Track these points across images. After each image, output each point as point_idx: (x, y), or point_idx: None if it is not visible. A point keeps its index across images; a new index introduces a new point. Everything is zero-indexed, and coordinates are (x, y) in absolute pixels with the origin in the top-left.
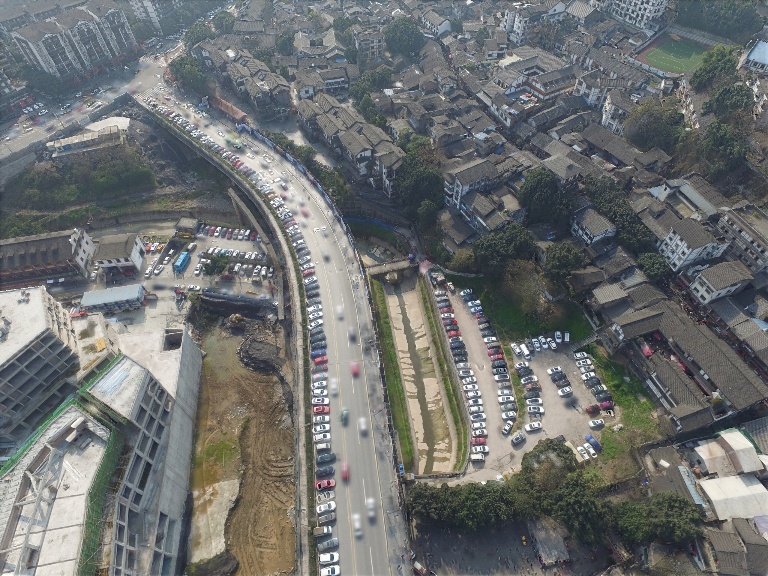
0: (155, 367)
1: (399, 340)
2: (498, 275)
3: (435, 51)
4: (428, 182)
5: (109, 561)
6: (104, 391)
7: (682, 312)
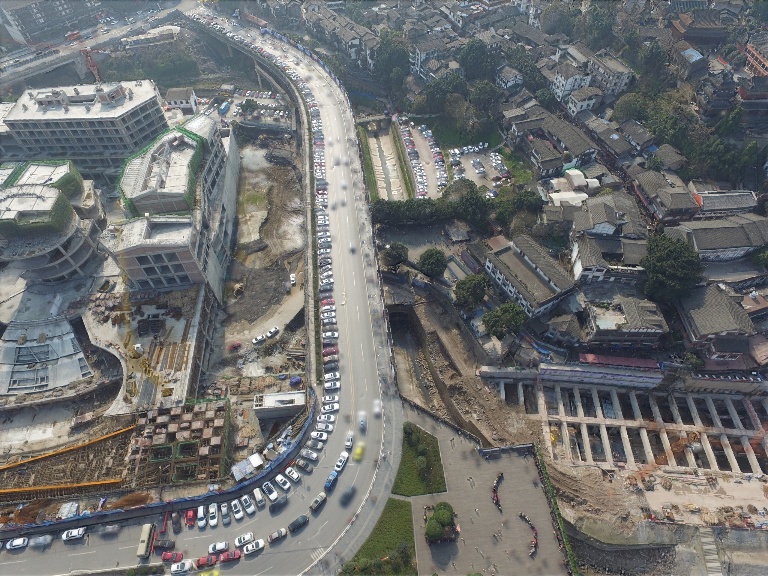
0: None
1: (375, 160)
2: (442, 107)
3: None
4: (398, 55)
5: (201, 196)
6: (191, 127)
7: (558, 119)
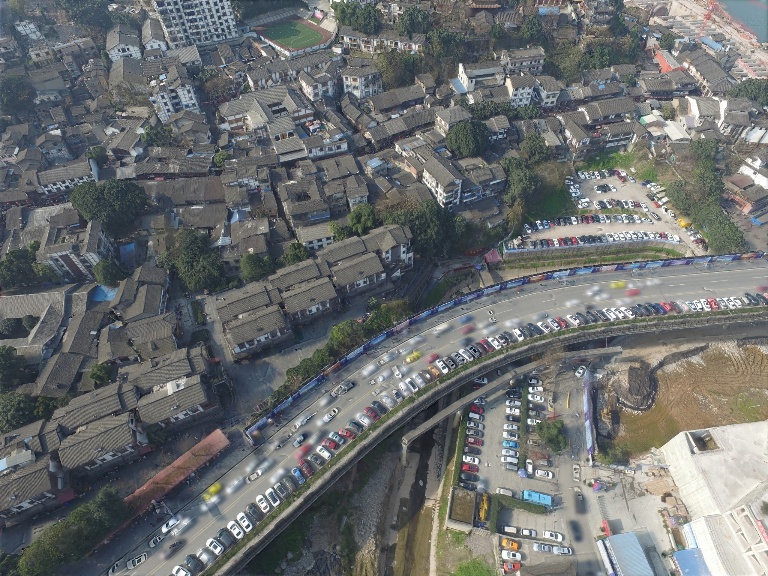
0: (743, 451)
1: None
2: None
3: (160, 183)
4: (442, 209)
5: None
6: None
7: None
